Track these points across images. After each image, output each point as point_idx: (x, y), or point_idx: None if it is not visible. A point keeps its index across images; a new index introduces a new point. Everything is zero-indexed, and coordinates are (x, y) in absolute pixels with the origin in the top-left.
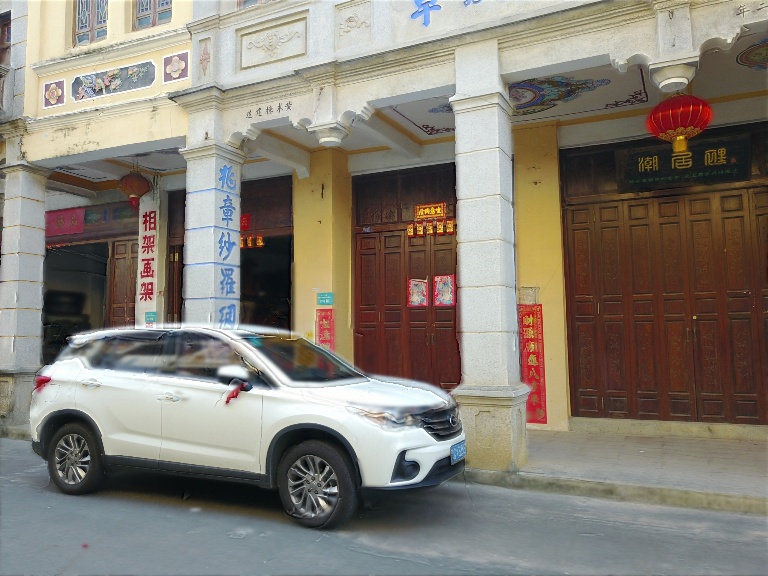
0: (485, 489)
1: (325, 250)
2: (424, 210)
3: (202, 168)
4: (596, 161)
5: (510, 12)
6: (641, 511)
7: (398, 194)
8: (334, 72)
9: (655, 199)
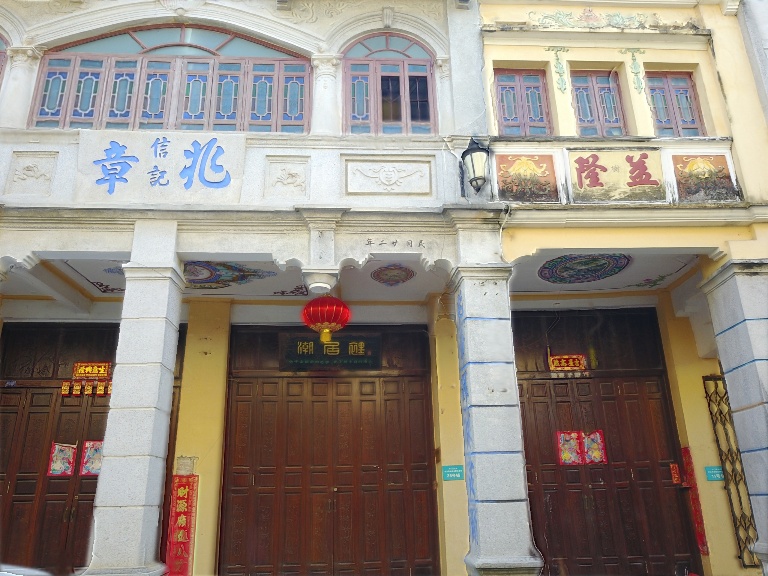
0: None
1: None
2: (85, 368)
3: None
4: (263, 339)
5: (192, 201)
6: None
7: (58, 348)
8: None
9: (310, 379)
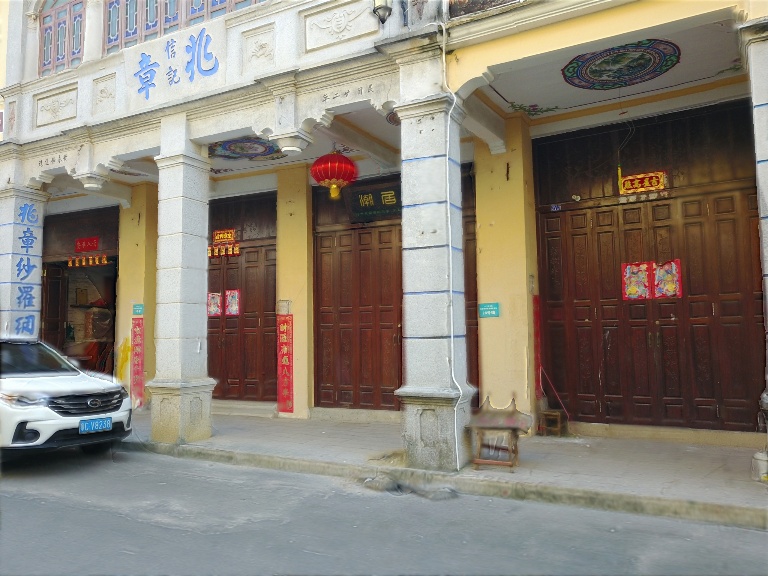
0: (156, 457)
1: (139, 269)
2: (220, 235)
3: (6, 206)
4: (337, 196)
5: (196, 91)
6: (240, 471)
7: None
8: (88, 133)
9: (376, 228)
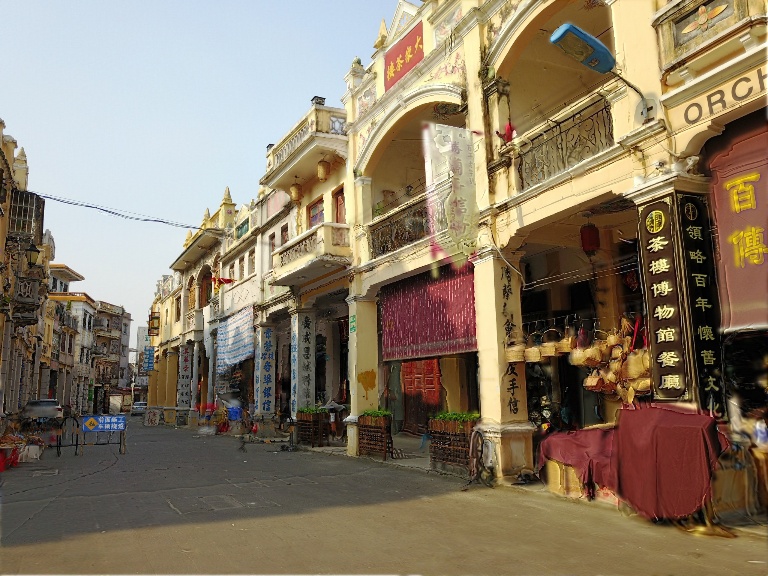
0: None
1: None
2: None
3: None
4: None
5: None
6: None
7: None
8: None
9: None
